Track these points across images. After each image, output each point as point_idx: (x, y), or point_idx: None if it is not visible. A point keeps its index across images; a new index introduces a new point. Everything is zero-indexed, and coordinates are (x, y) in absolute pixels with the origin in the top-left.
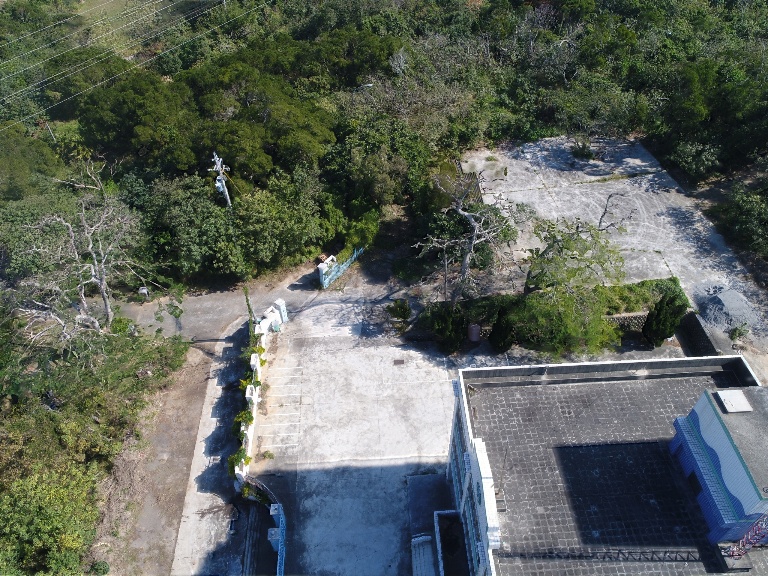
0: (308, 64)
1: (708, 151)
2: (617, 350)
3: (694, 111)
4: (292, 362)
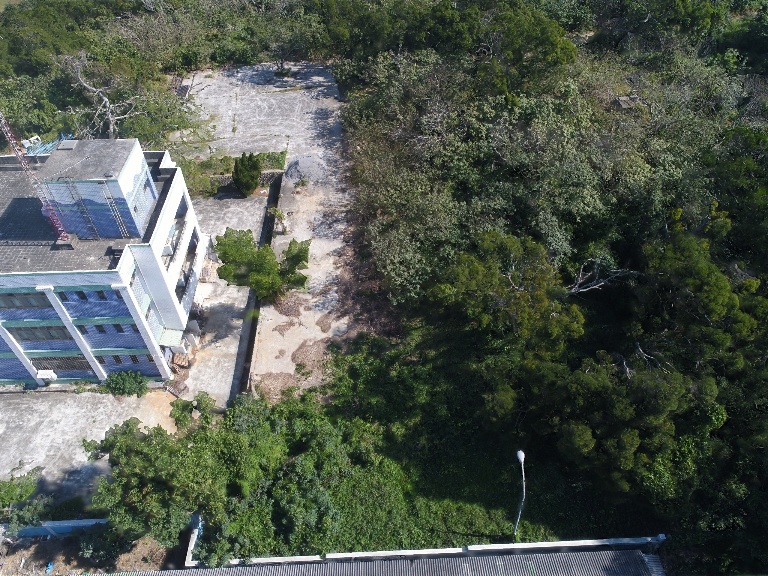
0: (97, 7)
1: (350, 64)
2: (219, 198)
3: (336, 32)
4: None
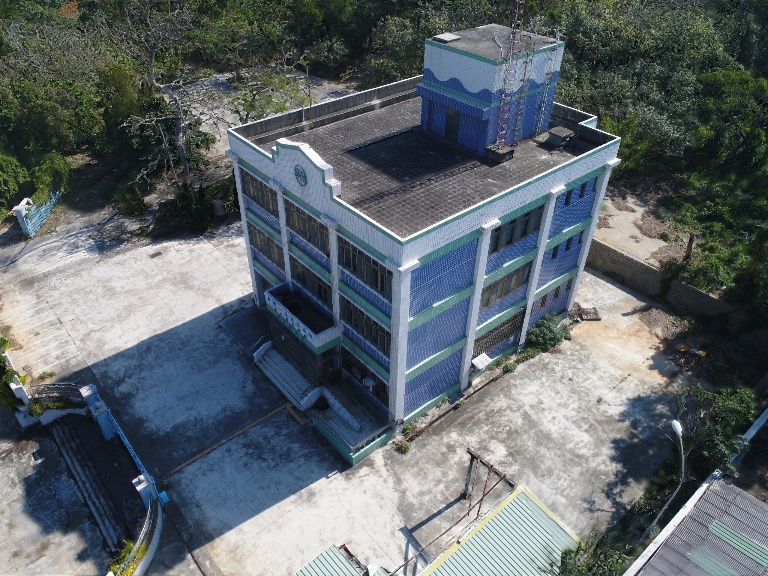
0: None
1: (336, 44)
2: None
3: (312, 13)
4: (28, 299)
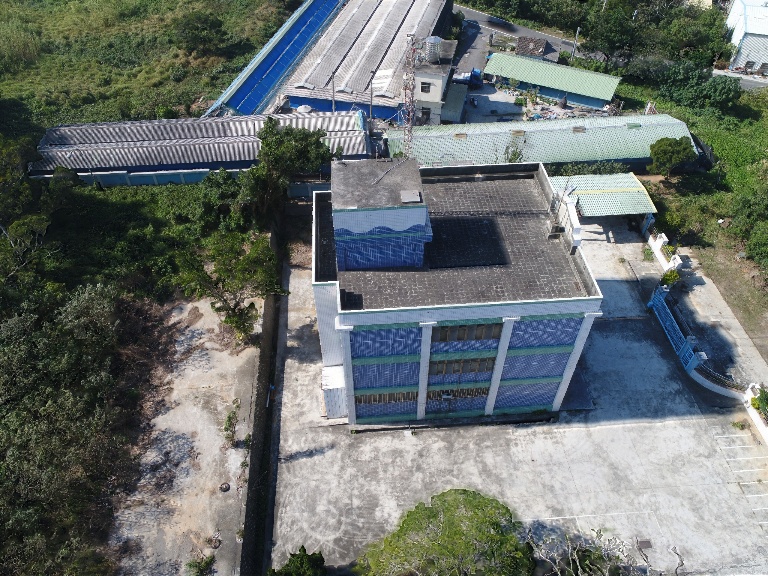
0: None
1: None
2: None
3: None
4: None
